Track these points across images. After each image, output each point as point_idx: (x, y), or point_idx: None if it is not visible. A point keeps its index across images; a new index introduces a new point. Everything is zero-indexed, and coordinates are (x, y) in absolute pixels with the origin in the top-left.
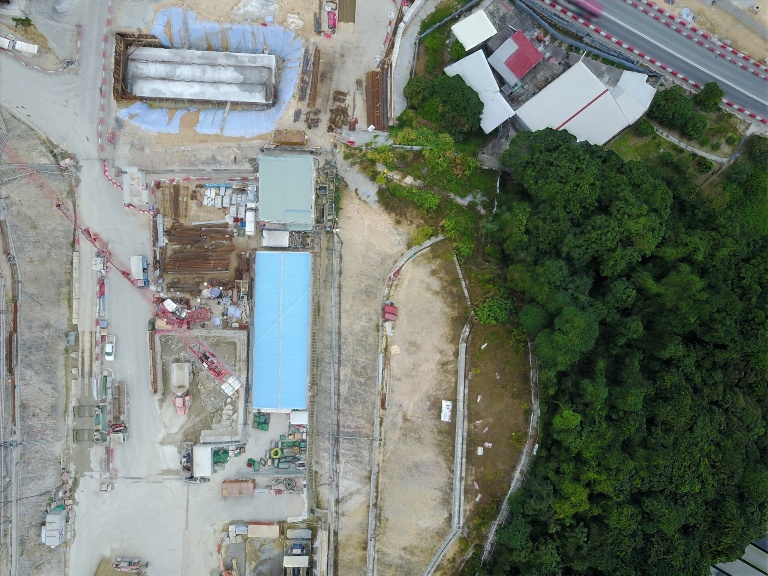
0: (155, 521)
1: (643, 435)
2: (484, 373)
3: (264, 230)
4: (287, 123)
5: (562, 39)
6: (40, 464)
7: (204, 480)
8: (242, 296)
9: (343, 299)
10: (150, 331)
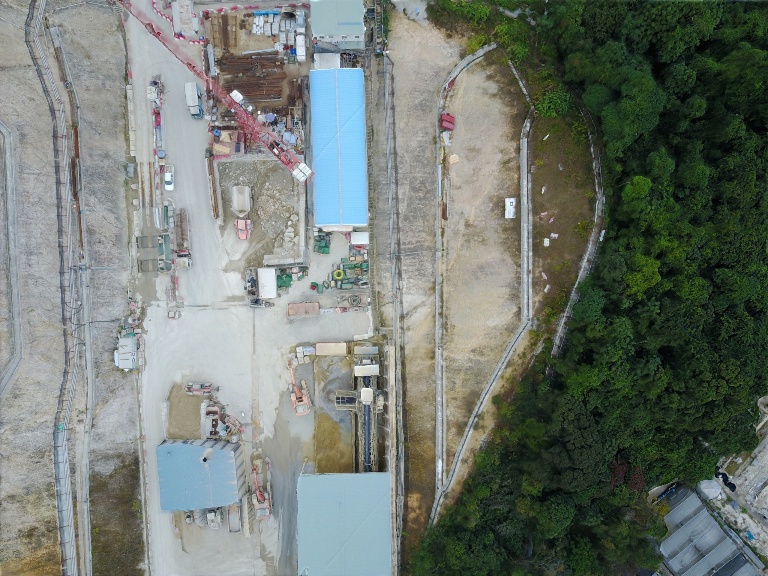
0: (223, 347)
1: (709, 214)
2: (547, 165)
3: (315, 53)
4: None
5: None
6: (108, 291)
7: (269, 304)
8: (296, 122)
9: (397, 119)
10: (208, 158)
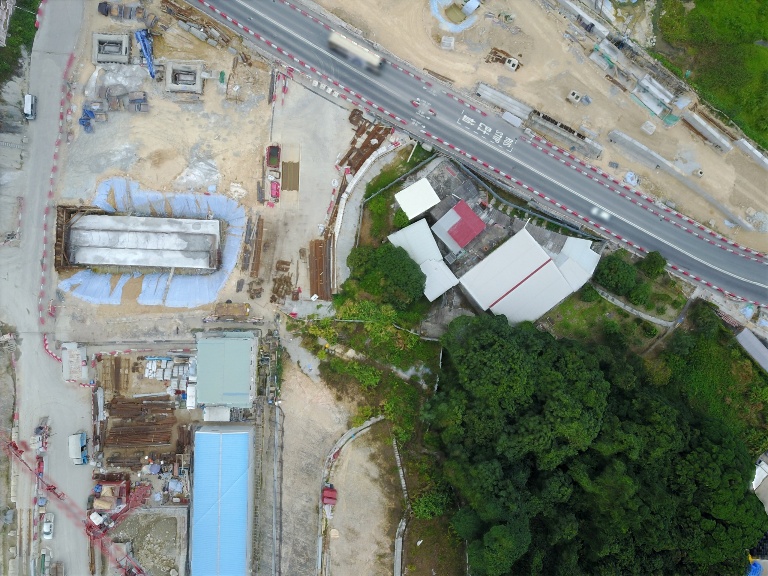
0: None
1: None
2: (420, 569)
3: None
4: (230, 293)
5: (507, 203)
6: None
7: None
8: (183, 470)
9: (285, 474)
10: (89, 510)
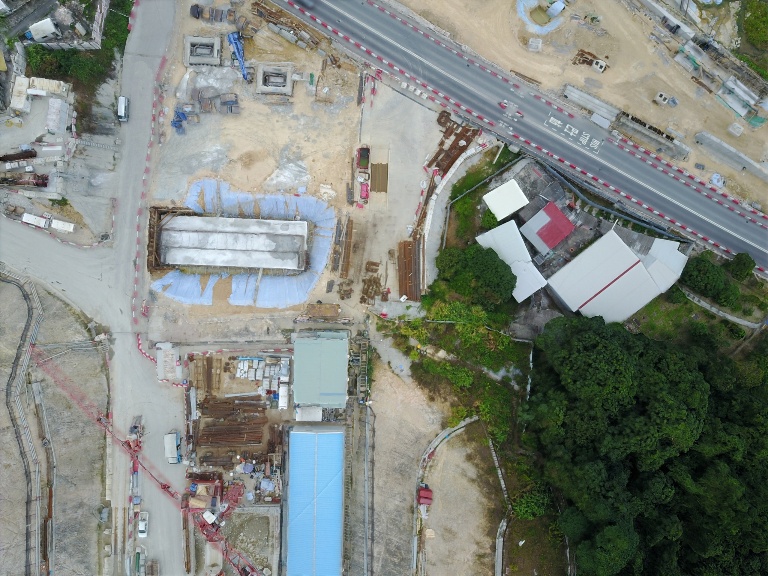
0: None
1: None
2: (522, 570)
3: None
4: (320, 294)
5: (593, 205)
6: None
7: None
8: (275, 470)
9: (376, 474)
10: (183, 509)
